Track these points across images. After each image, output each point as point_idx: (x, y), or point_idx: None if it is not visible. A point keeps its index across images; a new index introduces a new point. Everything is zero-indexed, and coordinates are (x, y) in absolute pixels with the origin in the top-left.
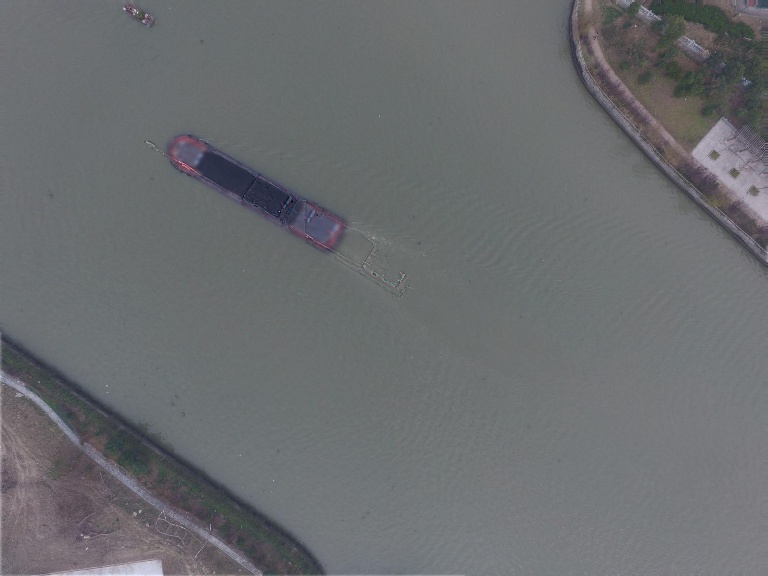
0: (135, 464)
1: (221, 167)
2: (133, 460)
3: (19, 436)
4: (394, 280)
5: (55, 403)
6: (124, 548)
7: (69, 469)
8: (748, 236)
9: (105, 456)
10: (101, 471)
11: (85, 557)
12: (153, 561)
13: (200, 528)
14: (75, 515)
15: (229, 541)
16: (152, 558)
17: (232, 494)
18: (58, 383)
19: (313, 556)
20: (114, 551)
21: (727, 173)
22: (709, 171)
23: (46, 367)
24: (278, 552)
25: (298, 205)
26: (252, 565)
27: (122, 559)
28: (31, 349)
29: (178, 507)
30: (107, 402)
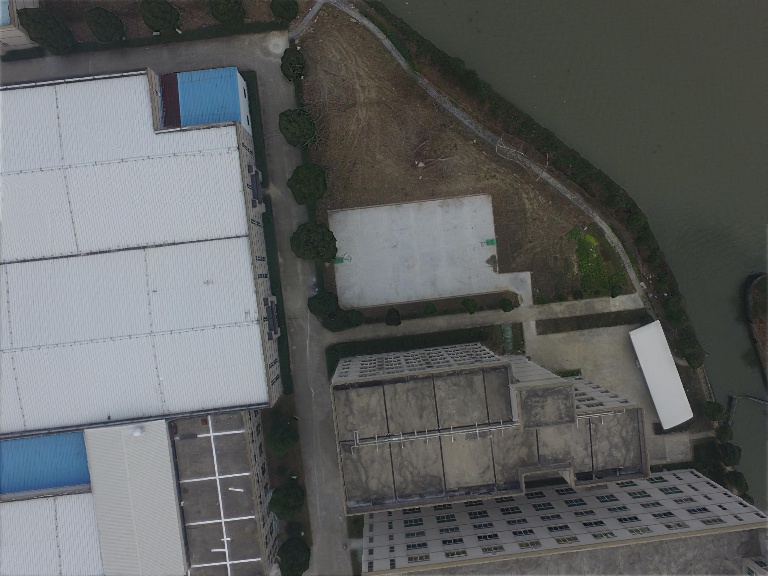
0: None
1: None
2: None
3: (359, 55)
4: None
5: (389, 30)
6: (461, 175)
7: (407, 93)
8: None
9: (438, 87)
10: (434, 102)
11: (418, 186)
12: (483, 196)
13: (532, 163)
14: (410, 142)
15: (564, 172)
16: (482, 192)
17: None
18: None
19: None
20: (451, 177)
21: None
22: None
23: None
24: (606, 192)
25: None
26: (582, 202)
27: (453, 192)
28: None
29: None
30: None
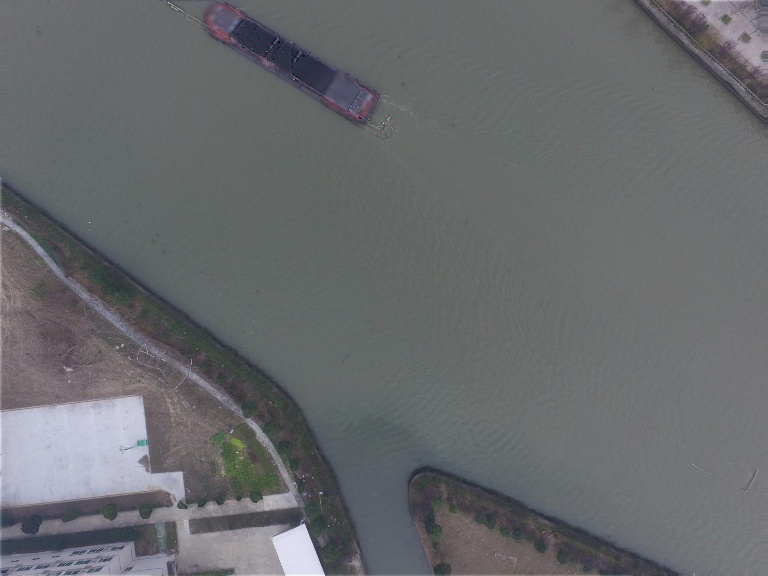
0: (118, 292)
1: (209, 6)
2: (116, 289)
3: (5, 266)
4: (380, 123)
5: (41, 237)
6: (106, 380)
7: (53, 301)
8: (739, 81)
9: (89, 291)
10: (85, 306)
11: (67, 390)
12: (135, 397)
13: (182, 365)
14: (58, 347)
15: (210, 376)
16: (134, 394)
17: (214, 336)
18: (45, 219)
19: (294, 400)
20: (96, 383)
21: (718, 19)
22: (699, 10)
23: (33, 205)
24: (259, 391)
25: (285, 45)
26: (232, 403)
27: (104, 394)
28: (19, 189)
29: (160, 341)
30: (93, 243)
